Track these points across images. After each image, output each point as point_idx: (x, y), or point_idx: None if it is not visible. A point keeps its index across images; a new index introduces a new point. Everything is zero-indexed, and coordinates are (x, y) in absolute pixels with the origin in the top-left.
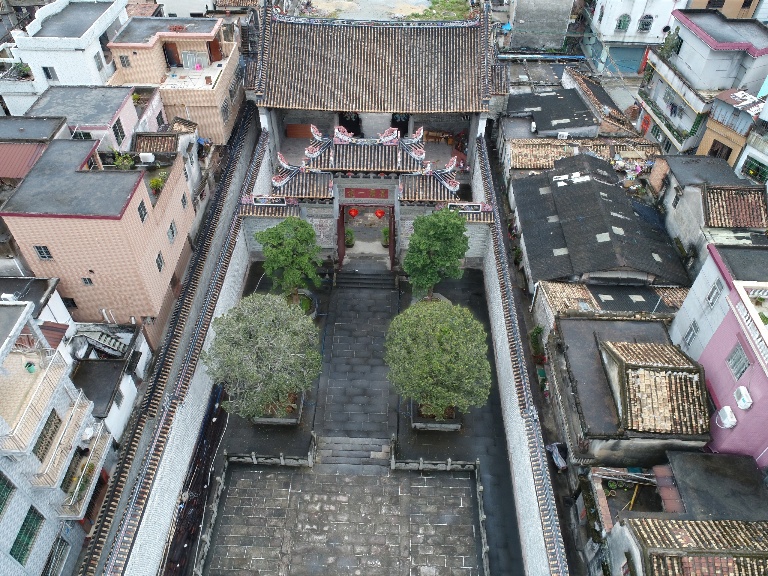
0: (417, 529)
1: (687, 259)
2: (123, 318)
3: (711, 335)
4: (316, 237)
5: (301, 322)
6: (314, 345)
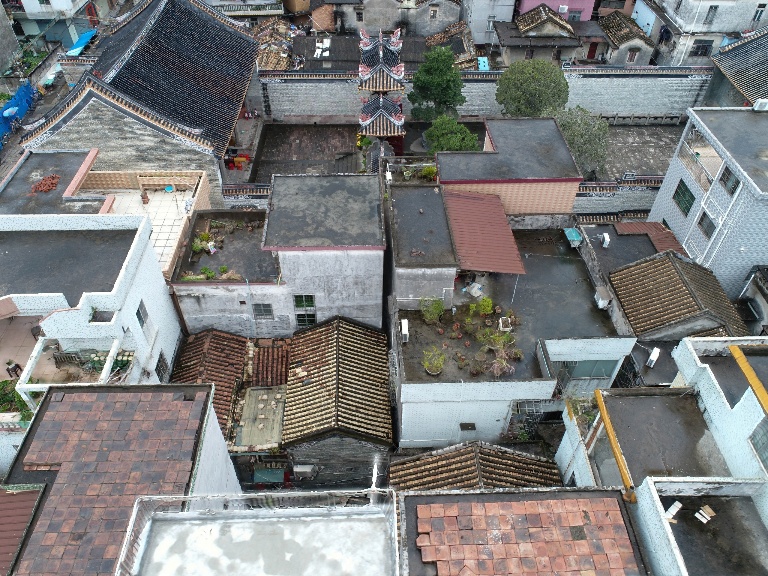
0: (611, 142)
1: None
2: None
3: (507, 8)
4: None
5: None
6: None
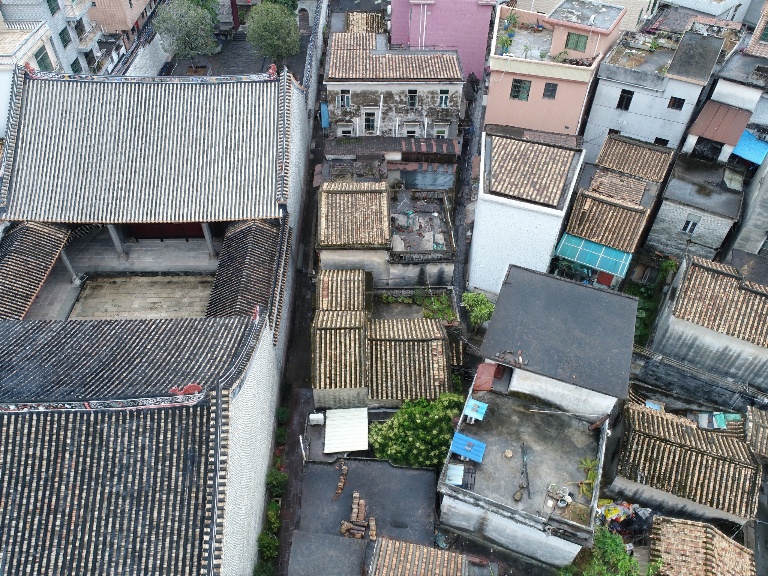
0: None
1: None
2: (112, 32)
3: None
4: (221, 14)
5: (201, 10)
6: (209, 24)
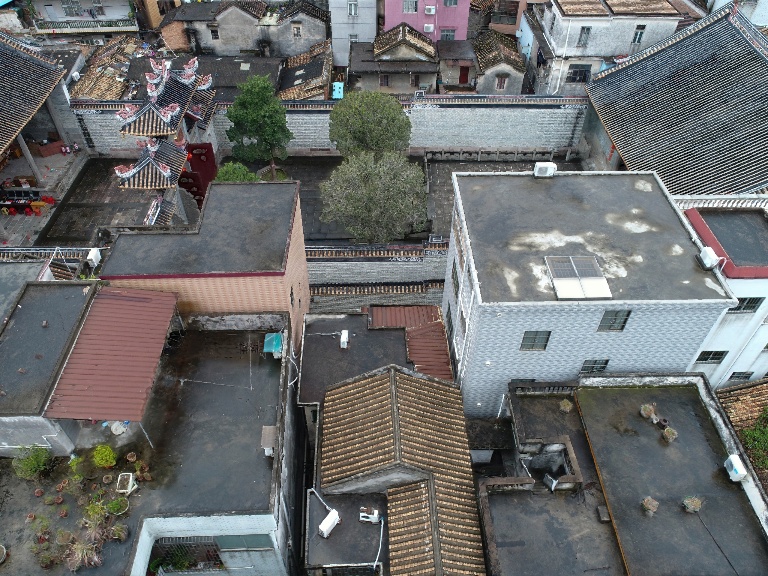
0: None
1: (263, 52)
2: None
3: (369, 26)
4: None
5: None
6: None
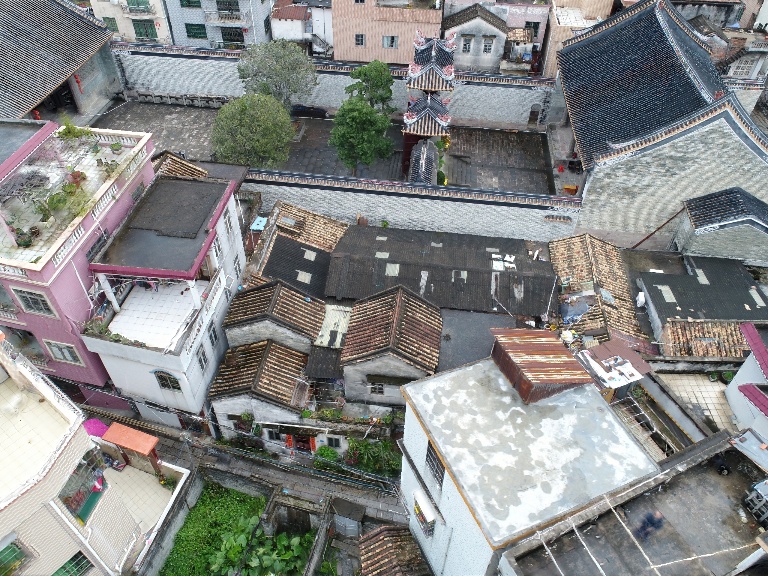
0: None
1: None
2: None
3: None
4: None
5: None
6: None
